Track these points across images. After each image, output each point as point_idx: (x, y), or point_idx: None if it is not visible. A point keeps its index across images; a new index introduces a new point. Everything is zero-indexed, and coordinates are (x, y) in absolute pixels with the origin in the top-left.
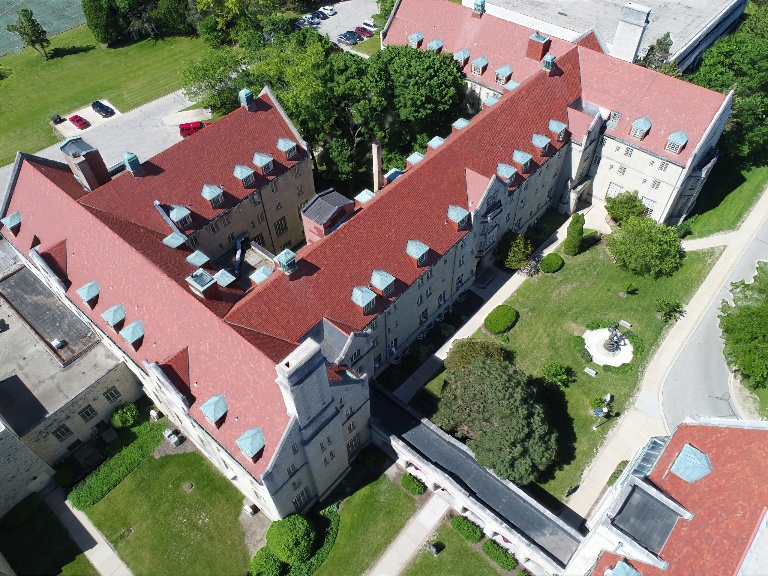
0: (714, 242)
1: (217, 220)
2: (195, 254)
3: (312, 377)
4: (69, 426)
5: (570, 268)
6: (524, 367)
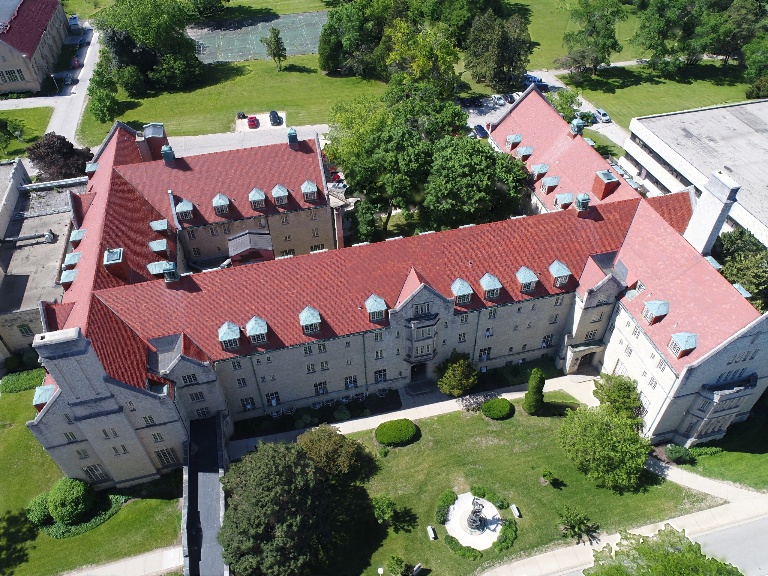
0: (715, 489)
1: (217, 226)
2: (159, 241)
3: (72, 361)
4: (32, 328)
5: (514, 424)
6: (375, 488)
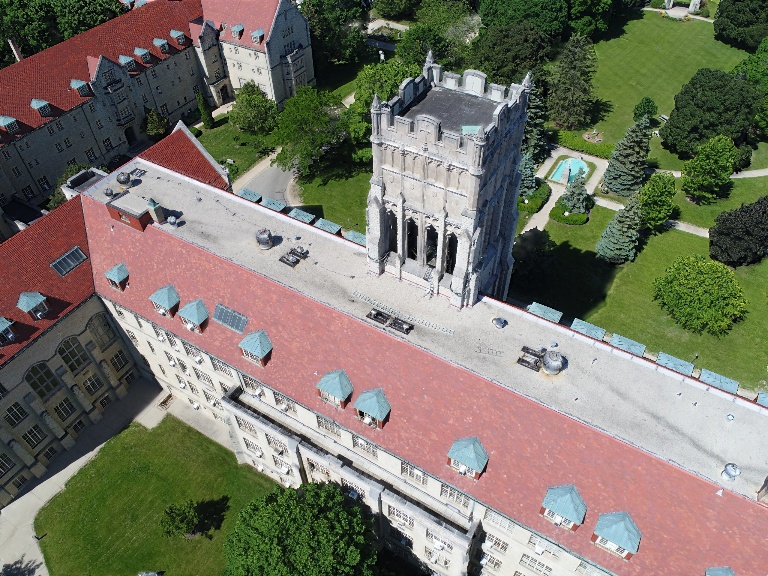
0: None
1: None
2: None
3: None
4: None
5: (205, 136)
6: None
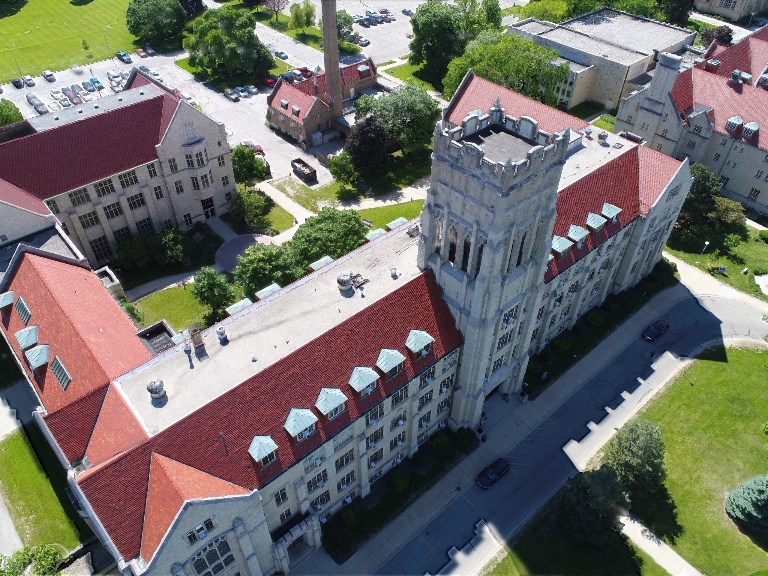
0: None
1: None
2: None
3: (667, 72)
4: None
5: None
6: None
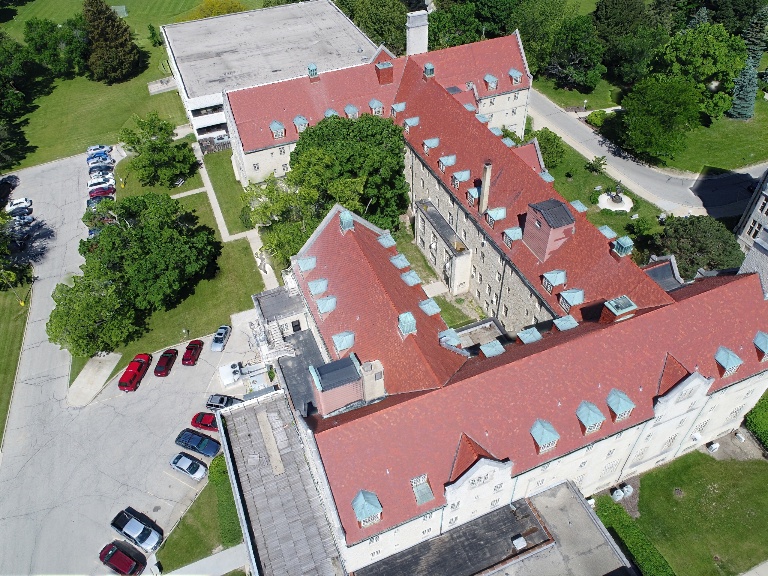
0: None
1: None
2: (527, 334)
3: None
4: None
5: None
6: None
